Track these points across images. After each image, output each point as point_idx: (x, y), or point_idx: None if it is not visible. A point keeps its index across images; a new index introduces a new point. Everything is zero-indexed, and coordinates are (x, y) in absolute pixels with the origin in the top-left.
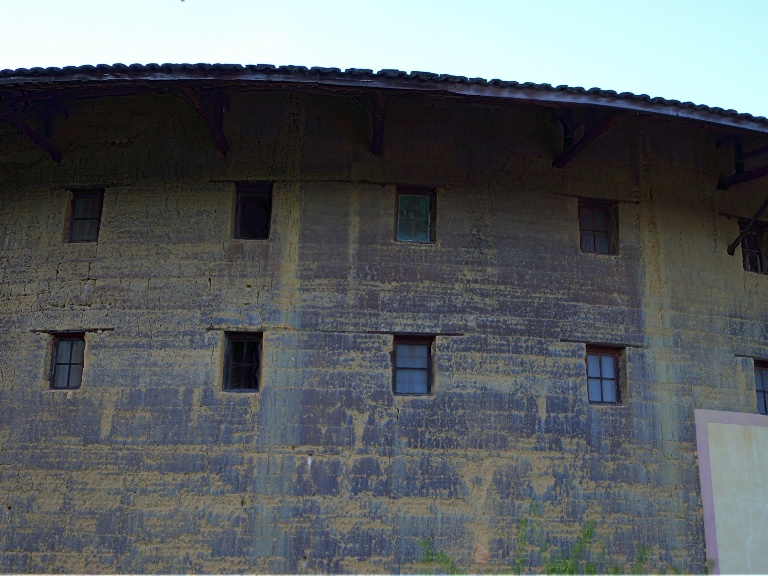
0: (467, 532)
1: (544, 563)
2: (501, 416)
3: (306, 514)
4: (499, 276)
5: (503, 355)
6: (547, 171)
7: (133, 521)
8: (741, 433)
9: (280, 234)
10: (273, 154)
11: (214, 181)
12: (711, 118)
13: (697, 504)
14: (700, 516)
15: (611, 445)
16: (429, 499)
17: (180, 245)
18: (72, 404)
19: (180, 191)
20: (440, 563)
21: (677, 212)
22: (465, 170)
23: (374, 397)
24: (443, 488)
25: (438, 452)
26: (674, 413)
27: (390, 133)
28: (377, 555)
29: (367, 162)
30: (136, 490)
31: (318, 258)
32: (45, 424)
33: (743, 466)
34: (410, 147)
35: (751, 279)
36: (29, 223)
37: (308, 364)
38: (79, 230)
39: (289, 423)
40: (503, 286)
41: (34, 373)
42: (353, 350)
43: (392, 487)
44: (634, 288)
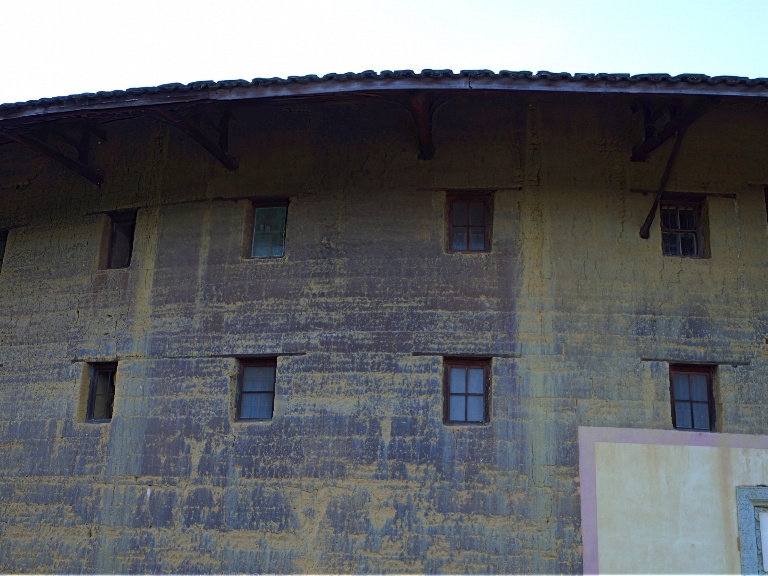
0: (296, 569)
1: None
2: (340, 441)
3: (142, 547)
4: (347, 287)
5: (346, 374)
6: (411, 165)
7: (3, 550)
8: (643, 454)
9: (139, 261)
10: (139, 181)
11: (89, 214)
12: (516, 85)
13: (575, 540)
14: (578, 555)
15: (466, 471)
16: (259, 532)
17: (58, 280)
18: None
19: (62, 227)
20: None
21: (572, 194)
22: (320, 175)
23: (212, 424)
24: (274, 521)
25: (271, 482)
26: (550, 432)
27: (246, 145)
28: None
29: (222, 178)
30: (7, 520)
31: (170, 283)
32: None
33: (644, 494)
34: (265, 157)
35: (672, 265)
36: None
37: (154, 392)
38: None
39: (133, 453)
40: (351, 298)
41: None
42: (195, 376)
43: (223, 519)
44: (507, 288)
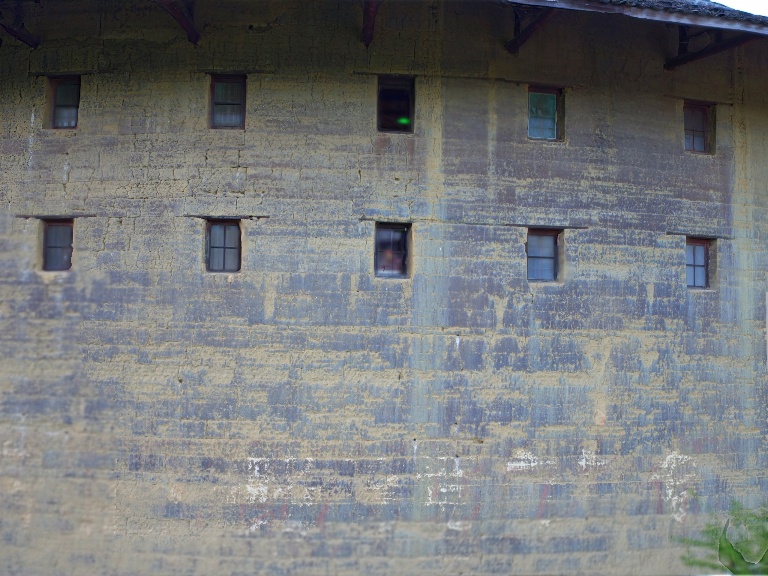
0: (589, 400)
1: (649, 424)
2: (618, 301)
3: (456, 387)
4: (618, 174)
5: (620, 247)
6: (659, 73)
7: (302, 393)
8: None
9: (424, 129)
10: (414, 48)
11: (358, 73)
12: None
13: (764, 372)
14: (765, 382)
15: (703, 324)
16: (559, 373)
17: (329, 136)
18: (234, 287)
19: (324, 81)
20: (567, 426)
21: (762, 114)
22: (590, 71)
23: (512, 284)
24: (570, 363)
25: (566, 332)
26: (751, 296)
27: None
28: (517, 420)
29: (503, 60)
30: (303, 366)
31: (460, 154)
32: (209, 305)
33: None
34: (542, 46)
35: None
36: (170, 106)
37: (454, 254)
38: (220, 115)
39: (439, 307)
40: (621, 183)
41: (193, 257)
42: (494, 241)
43: (528, 363)
44: (726, 185)
